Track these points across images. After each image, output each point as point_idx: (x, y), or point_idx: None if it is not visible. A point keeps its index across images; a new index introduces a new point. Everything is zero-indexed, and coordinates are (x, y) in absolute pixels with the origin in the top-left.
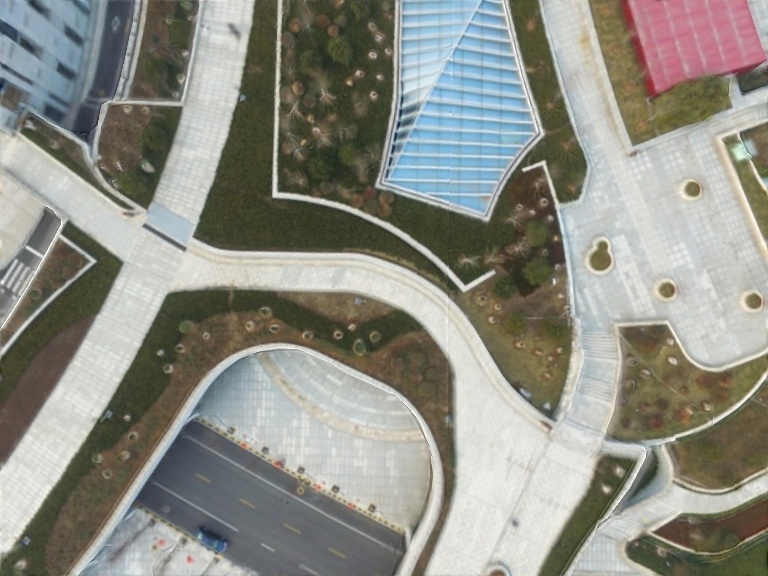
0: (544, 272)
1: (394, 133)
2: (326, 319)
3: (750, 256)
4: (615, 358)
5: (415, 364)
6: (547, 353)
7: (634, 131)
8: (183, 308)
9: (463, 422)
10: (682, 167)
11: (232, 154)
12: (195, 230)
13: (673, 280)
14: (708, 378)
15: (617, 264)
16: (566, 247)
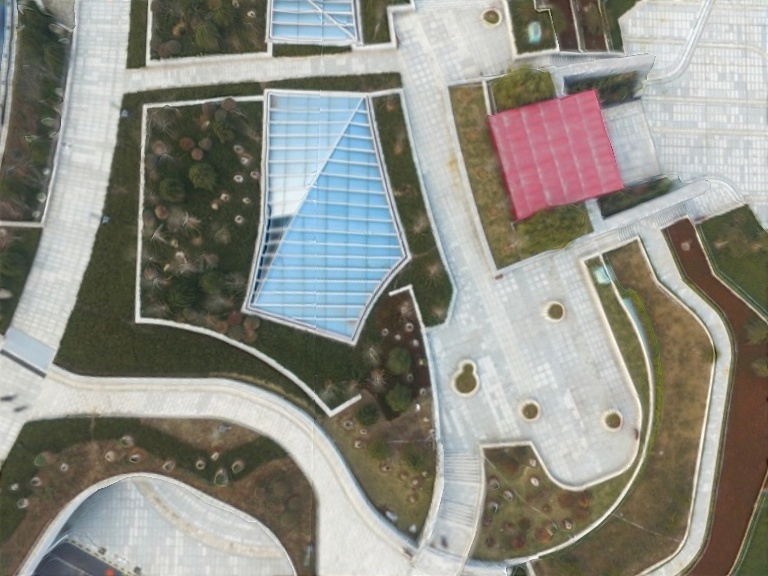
0: (408, 398)
1: (260, 257)
2: (190, 447)
3: (611, 375)
4: (478, 481)
5: (277, 494)
6: (413, 476)
7: (499, 254)
8: (41, 438)
9: (326, 551)
10: (547, 288)
11: (94, 277)
12: (55, 355)
13: (537, 401)
14: (569, 497)
15: (483, 385)
16: (432, 371)
